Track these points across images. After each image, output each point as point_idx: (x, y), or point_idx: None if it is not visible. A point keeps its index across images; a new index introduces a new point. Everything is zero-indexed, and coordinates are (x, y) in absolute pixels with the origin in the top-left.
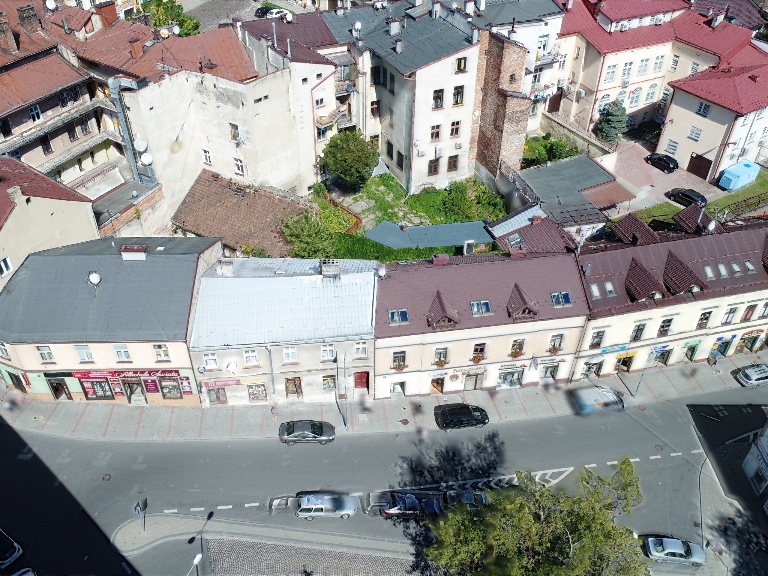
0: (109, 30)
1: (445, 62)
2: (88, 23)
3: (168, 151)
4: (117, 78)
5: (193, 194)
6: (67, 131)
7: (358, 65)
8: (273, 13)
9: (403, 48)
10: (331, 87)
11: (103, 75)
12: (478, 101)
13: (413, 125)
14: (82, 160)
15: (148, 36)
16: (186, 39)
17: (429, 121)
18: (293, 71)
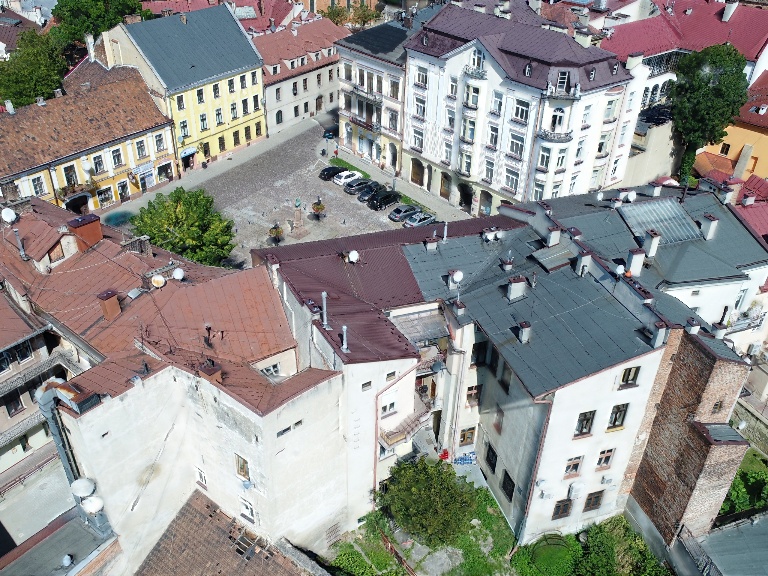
0: (86, 258)
1: (604, 375)
2: (55, 248)
3: (133, 485)
4: (50, 388)
5: (173, 535)
6: (4, 403)
7: (454, 340)
8: (342, 177)
9: (530, 332)
10: (408, 386)
11: (63, 331)
12: (647, 420)
13: (538, 459)
14: (28, 436)
15: (136, 278)
16: (191, 289)
17: (565, 452)
18: (348, 376)
